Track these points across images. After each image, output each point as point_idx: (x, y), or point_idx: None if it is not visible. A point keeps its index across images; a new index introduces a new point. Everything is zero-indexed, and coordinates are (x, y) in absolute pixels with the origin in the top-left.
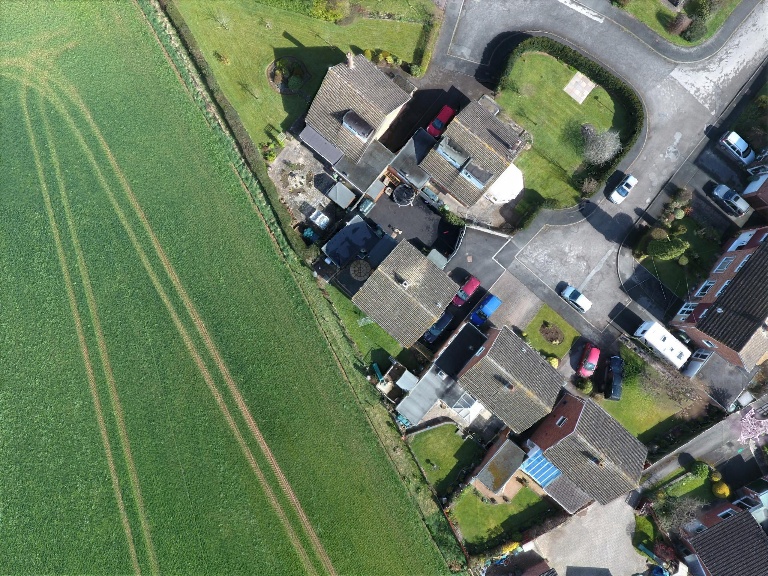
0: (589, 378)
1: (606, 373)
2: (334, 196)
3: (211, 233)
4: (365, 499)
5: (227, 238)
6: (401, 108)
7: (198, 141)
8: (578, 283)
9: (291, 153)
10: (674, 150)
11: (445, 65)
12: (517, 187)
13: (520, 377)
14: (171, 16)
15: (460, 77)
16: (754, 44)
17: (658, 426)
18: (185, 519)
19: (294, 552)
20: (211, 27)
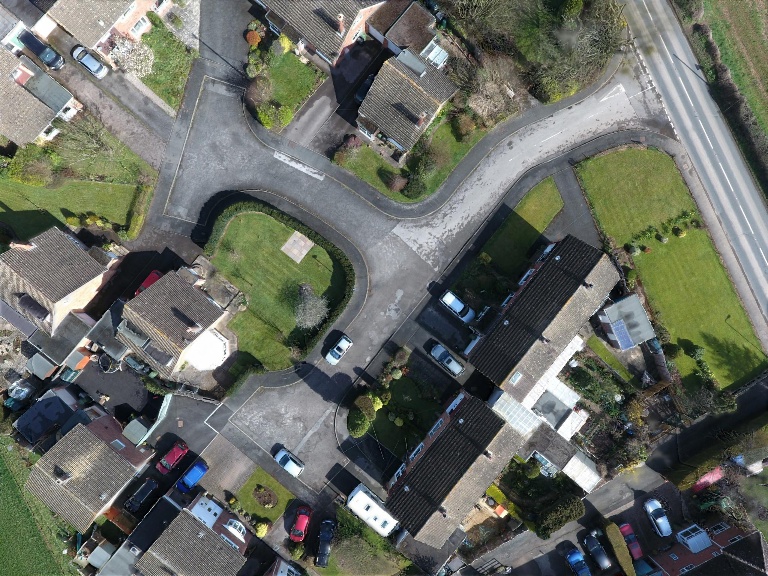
0: (303, 542)
1: None
2: (31, 368)
3: None
4: None
5: None
6: (104, 276)
7: None
8: (294, 445)
9: None
10: (395, 308)
11: (160, 226)
12: (216, 358)
13: (186, 568)
14: None
15: (175, 238)
16: (479, 199)
17: None
18: None
19: None
20: None
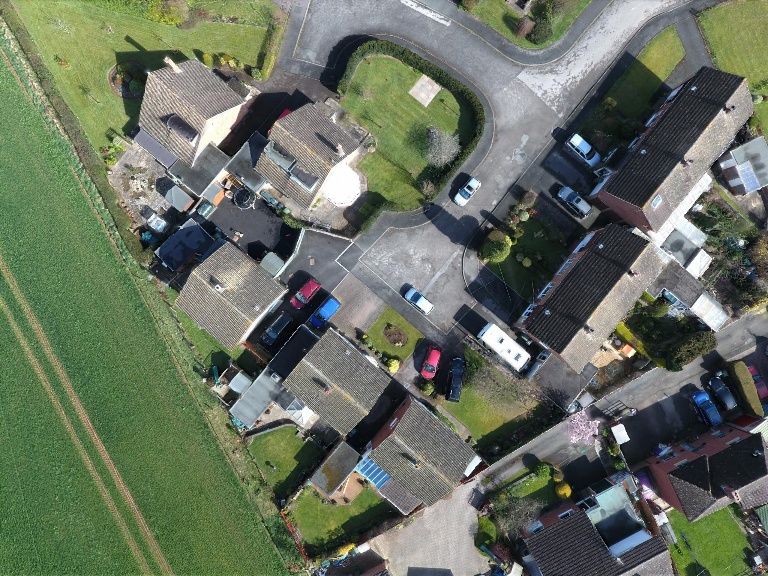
0: (432, 380)
1: (448, 375)
2: (170, 200)
3: (50, 237)
4: (204, 501)
5: (66, 242)
6: (240, 112)
7: (37, 145)
8: (423, 285)
9: (133, 157)
10: (521, 152)
11: (290, 68)
12: (353, 190)
13: (338, 380)
14: (7, 21)
15: (305, 80)
16: (602, 46)
17: (503, 427)
18: (19, 522)
19: (130, 554)
20: (52, 31)
